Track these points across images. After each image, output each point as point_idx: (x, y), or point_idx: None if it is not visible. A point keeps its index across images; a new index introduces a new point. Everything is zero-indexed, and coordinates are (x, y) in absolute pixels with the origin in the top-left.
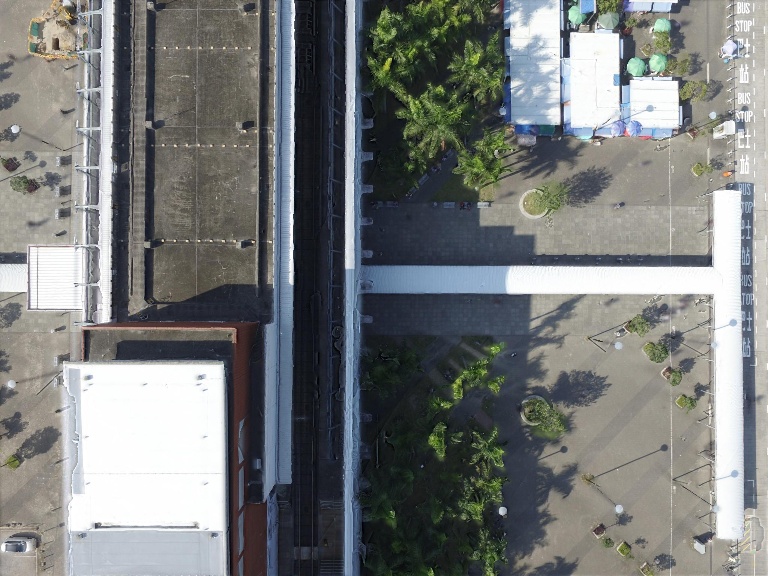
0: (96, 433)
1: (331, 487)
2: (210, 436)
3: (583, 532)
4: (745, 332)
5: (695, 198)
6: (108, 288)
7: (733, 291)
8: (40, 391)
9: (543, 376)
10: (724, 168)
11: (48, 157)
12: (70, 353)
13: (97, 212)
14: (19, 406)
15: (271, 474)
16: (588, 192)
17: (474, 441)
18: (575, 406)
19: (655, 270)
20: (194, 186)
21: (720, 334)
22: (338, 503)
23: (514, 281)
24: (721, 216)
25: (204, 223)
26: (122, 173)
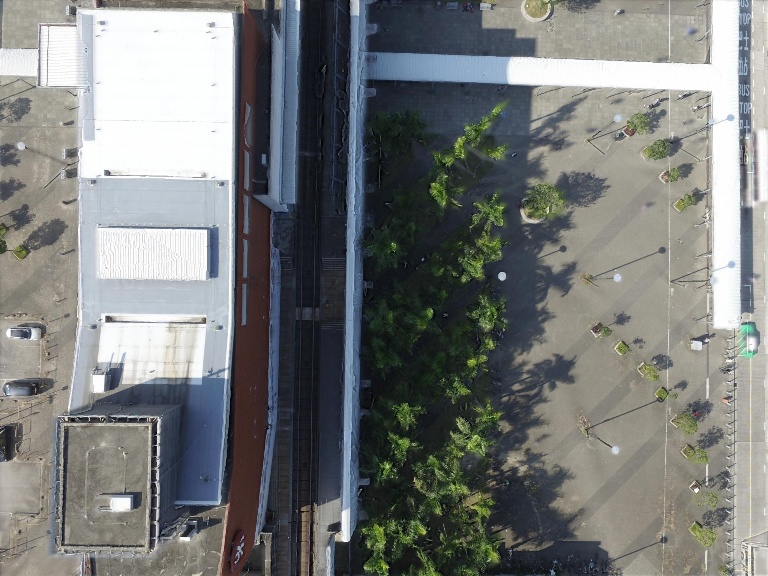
0: (107, 79)
1: (333, 245)
2: (218, 84)
3: (581, 330)
4: (743, 140)
5: (694, 8)
6: None
7: None
8: (47, 184)
9: (543, 176)
10: None
11: None
12: (78, 147)
13: None
14: (27, 199)
15: (275, 189)
16: None
17: (474, 212)
18: (574, 206)
19: (654, 64)
20: None
21: (718, 129)
22: (340, 262)
23: (515, 71)
24: (719, 14)
25: None
26: None
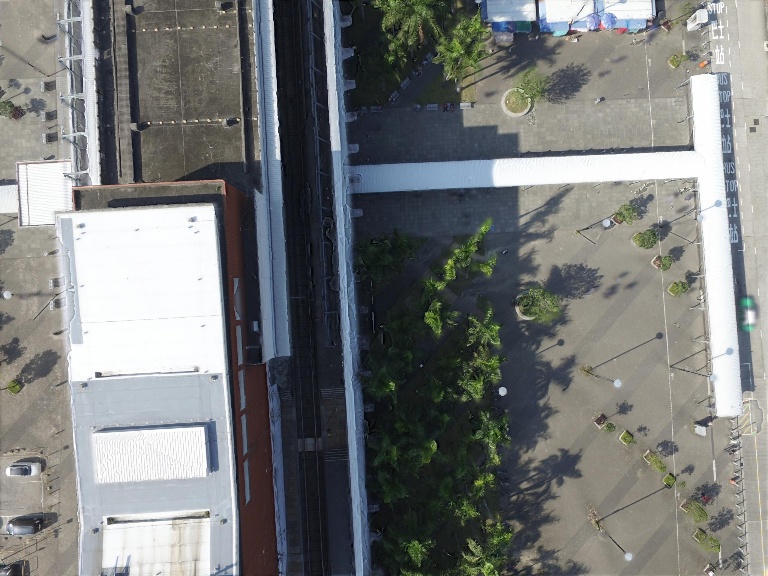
0: (91, 281)
1: (331, 375)
2: (204, 278)
3: (585, 423)
4: (731, 218)
5: (673, 89)
6: (97, 173)
7: (716, 175)
8: (37, 316)
9: (535, 271)
10: (700, 59)
11: (32, 84)
12: (65, 276)
13: (83, 112)
14: (16, 332)
15: (269, 345)
16: (568, 89)
17: (470, 326)
18: (569, 299)
19: (638, 156)
20: (177, 68)
21: (706, 216)
22: (339, 391)
23: (500, 174)
24: (699, 100)
25: (189, 104)
26: (105, 60)
